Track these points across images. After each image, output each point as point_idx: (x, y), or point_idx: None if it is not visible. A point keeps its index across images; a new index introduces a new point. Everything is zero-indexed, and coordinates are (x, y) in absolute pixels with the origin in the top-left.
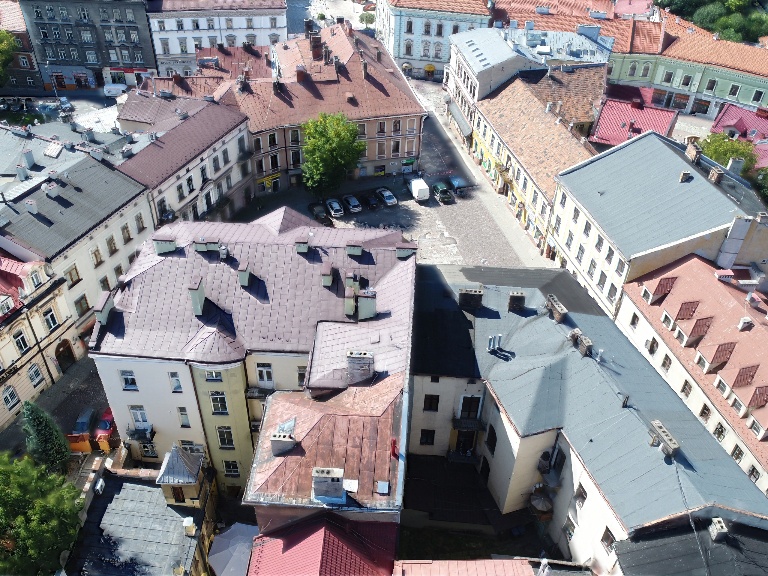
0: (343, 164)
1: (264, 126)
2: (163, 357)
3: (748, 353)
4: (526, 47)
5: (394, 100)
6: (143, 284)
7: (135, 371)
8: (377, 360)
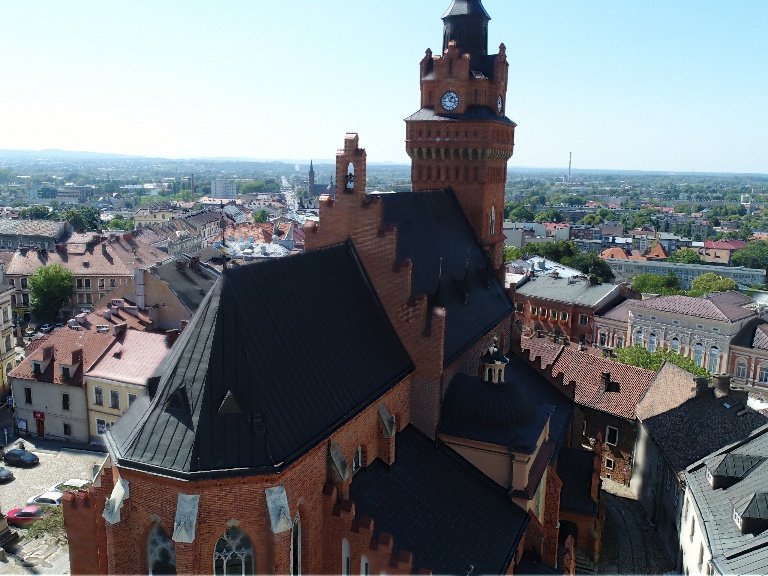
0: (49, 293)
1: (18, 272)
2: None
3: None
4: (239, 250)
5: (115, 267)
6: None
7: None
8: None
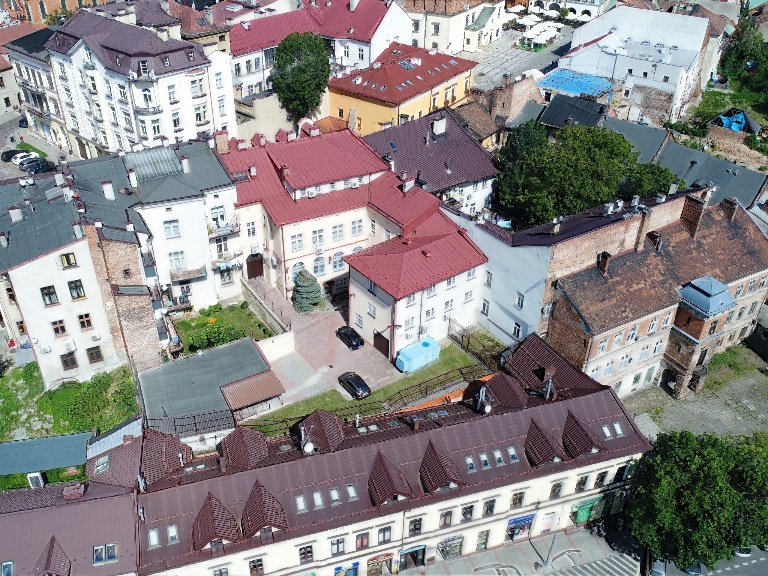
0: None
1: None
2: None
3: (3, 42)
4: None
5: None
6: None
7: None
8: (157, 7)
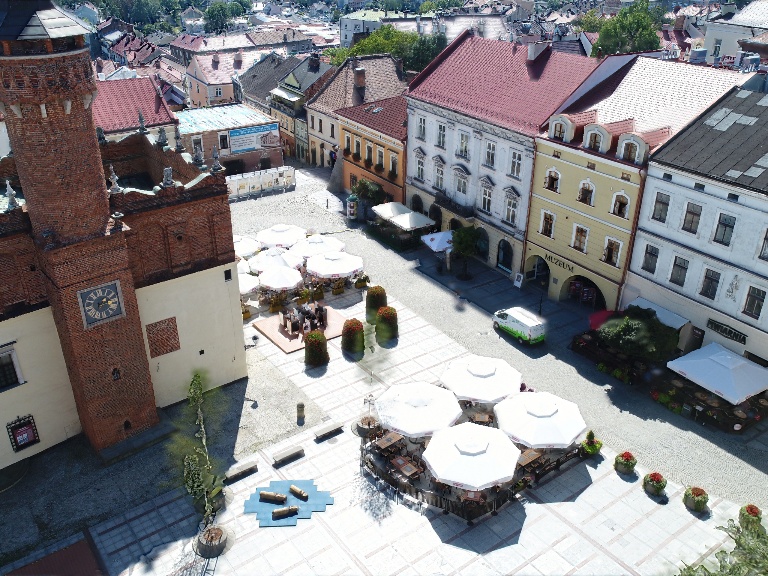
0: None
1: None
2: (742, 25)
3: None
4: None
5: None
6: (755, 4)
7: (723, 40)
8: None
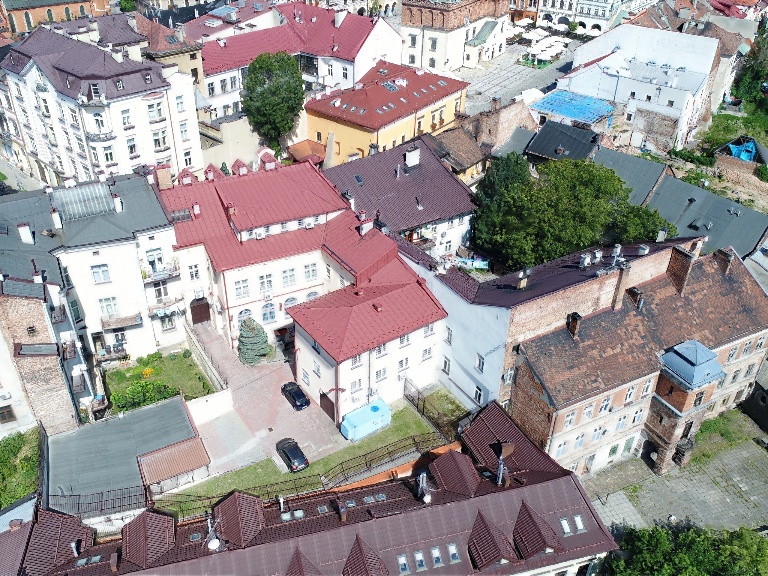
0: None
1: None
2: None
3: None
4: None
5: None
6: None
7: None
8: None
